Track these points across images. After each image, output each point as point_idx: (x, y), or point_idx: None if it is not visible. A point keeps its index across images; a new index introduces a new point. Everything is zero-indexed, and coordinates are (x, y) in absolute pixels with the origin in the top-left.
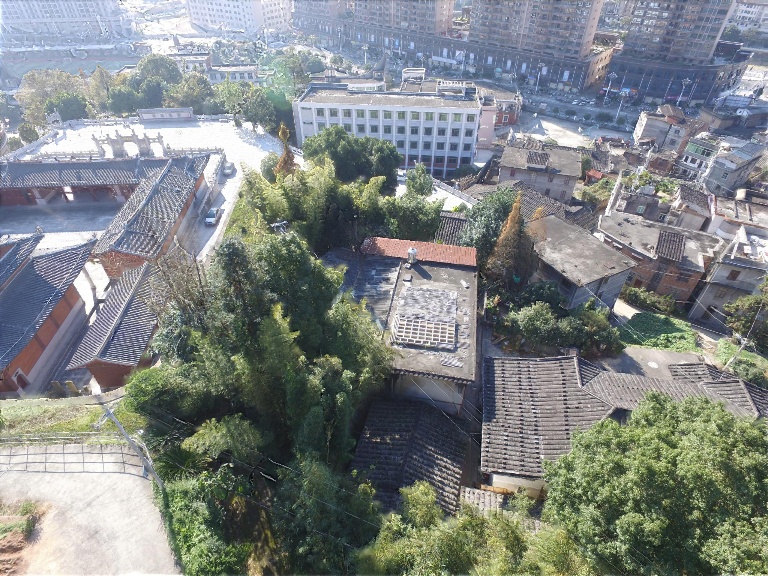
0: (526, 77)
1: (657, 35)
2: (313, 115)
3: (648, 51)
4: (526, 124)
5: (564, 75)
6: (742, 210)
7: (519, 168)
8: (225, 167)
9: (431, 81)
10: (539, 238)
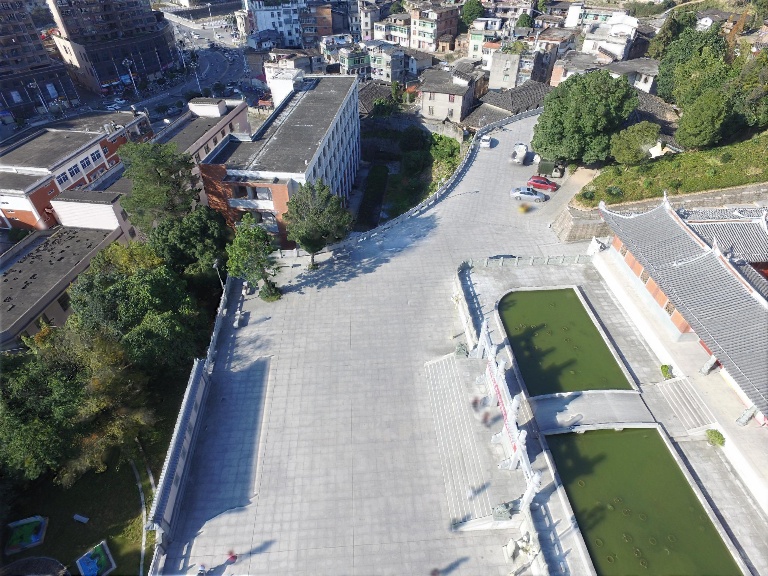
0: None
1: (97, 13)
2: None
3: (101, 33)
4: None
5: (49, 91)
6: None
7: (468, 88)
8: None
9: None
10: (629, 76)
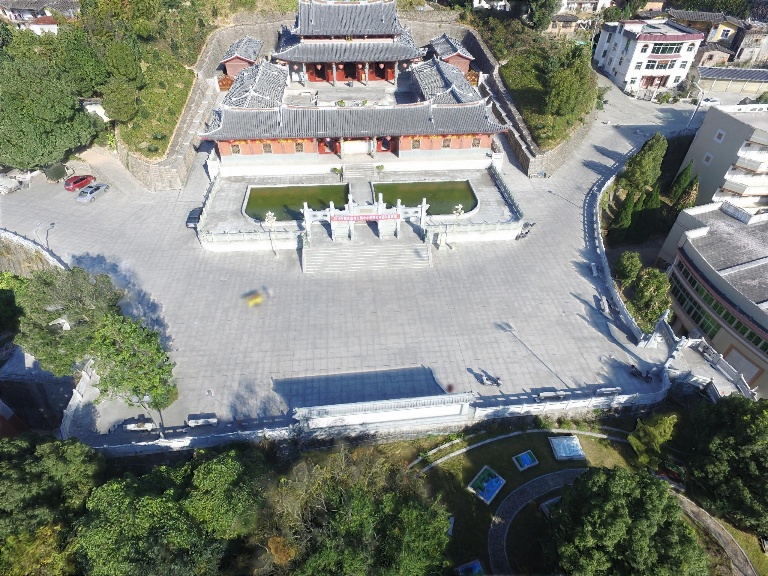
0: None
1: None
2: None
3: None
4: None
5: None
6: None
7: None
8: (201, 210)
9: None
10: None
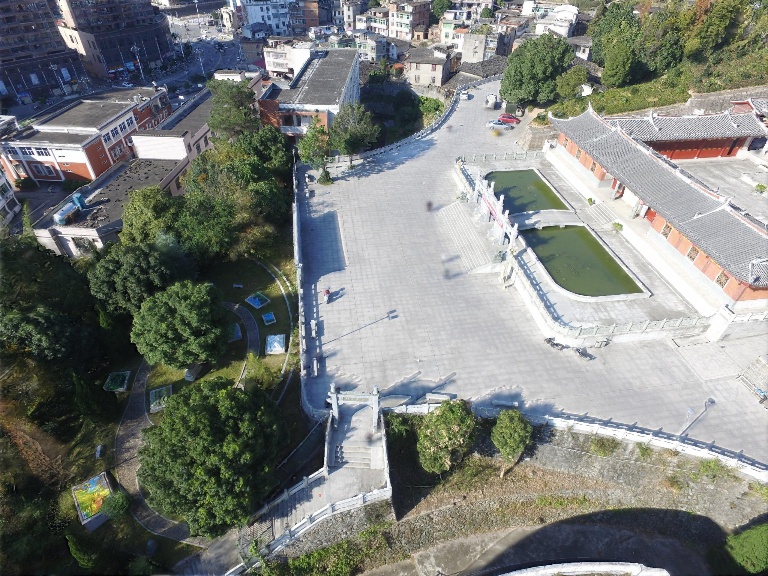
0: (15, 97)
1: (103, 5)
2: None
3: (106, 23)
4: None
5: (63, 74)
6: None
7: None
8: None
9: (42, 122)
10: None
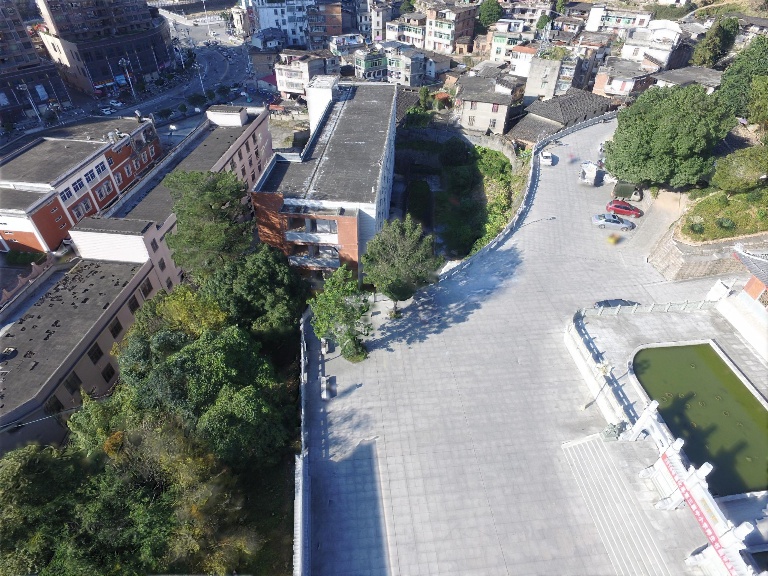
0: None
1: (89, 8)
2: (377, 210)
3: (93, 29)
4: (172, 144)
5: (38, 92)
6: (589, 40)
7: None
8: None
9: None
10: None
